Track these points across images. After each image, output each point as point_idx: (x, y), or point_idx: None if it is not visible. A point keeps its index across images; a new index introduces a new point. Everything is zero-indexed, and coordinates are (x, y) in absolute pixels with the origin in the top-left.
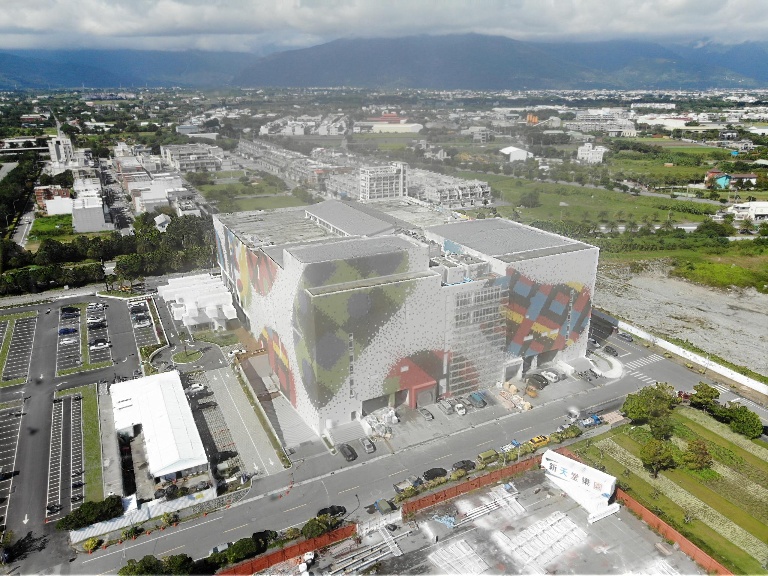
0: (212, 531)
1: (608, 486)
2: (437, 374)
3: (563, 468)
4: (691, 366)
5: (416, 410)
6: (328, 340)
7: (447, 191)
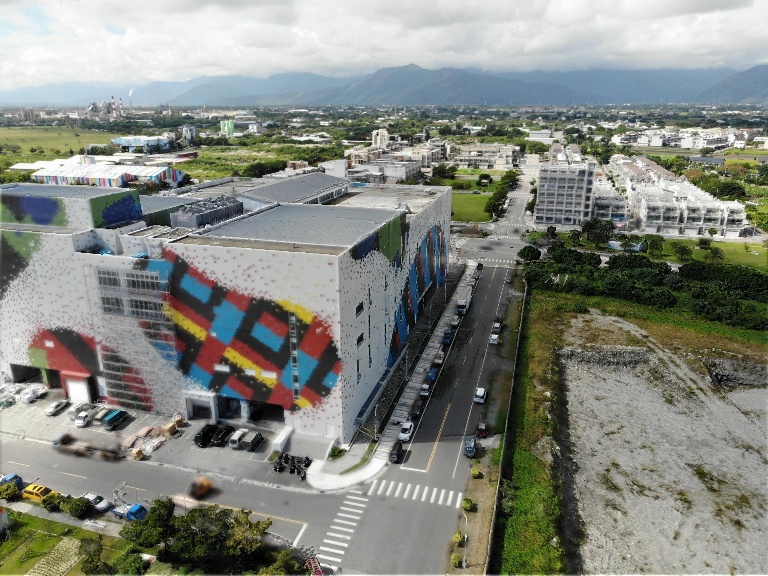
0: None
1: None
2: (92, 367)
3: None
4: (454, 540)
5: None
6: None
7: (662, 209)
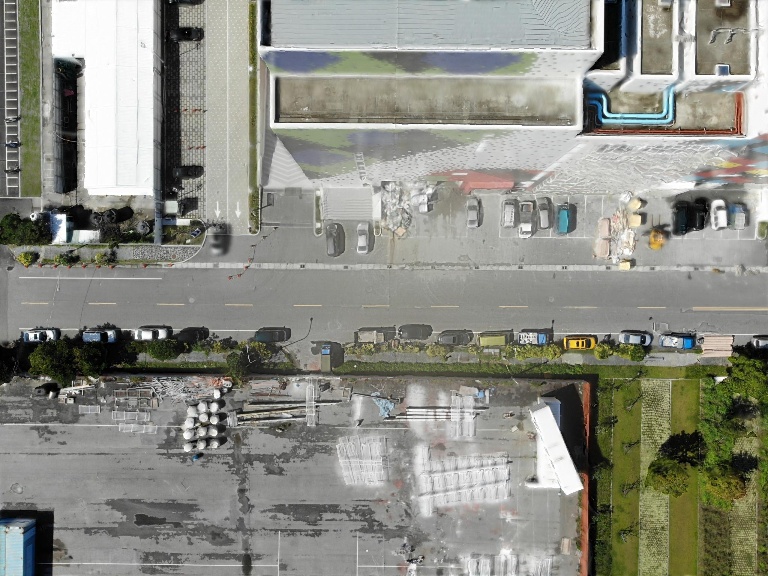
0: (146, 296)
1: (564, 491)
2: (519, 178)
3: (542, 438)
4: None
5: (466, 197)
6: (313, 153)
7: None
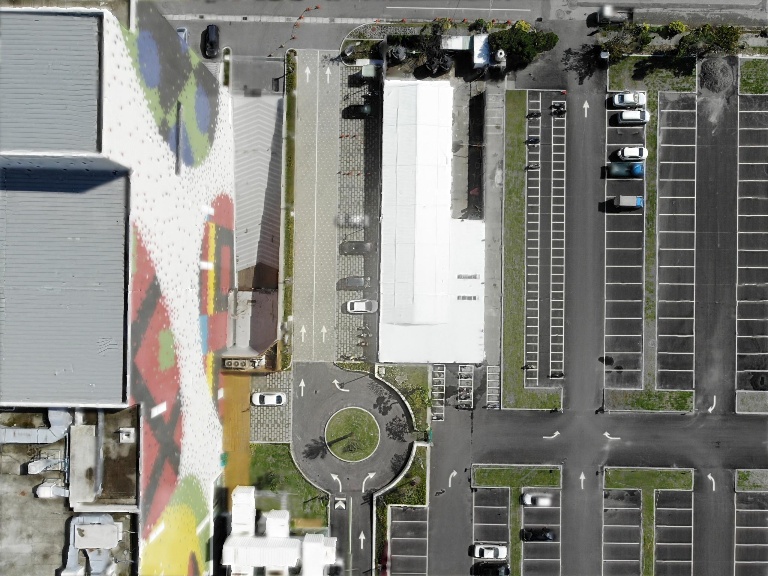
0: None
1: None
2: None
3: None
4: None
5: None
6: None
7: None
